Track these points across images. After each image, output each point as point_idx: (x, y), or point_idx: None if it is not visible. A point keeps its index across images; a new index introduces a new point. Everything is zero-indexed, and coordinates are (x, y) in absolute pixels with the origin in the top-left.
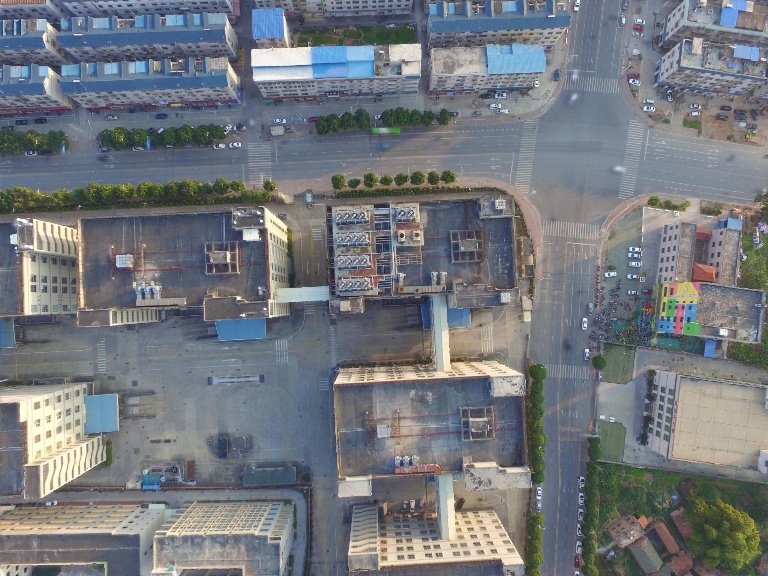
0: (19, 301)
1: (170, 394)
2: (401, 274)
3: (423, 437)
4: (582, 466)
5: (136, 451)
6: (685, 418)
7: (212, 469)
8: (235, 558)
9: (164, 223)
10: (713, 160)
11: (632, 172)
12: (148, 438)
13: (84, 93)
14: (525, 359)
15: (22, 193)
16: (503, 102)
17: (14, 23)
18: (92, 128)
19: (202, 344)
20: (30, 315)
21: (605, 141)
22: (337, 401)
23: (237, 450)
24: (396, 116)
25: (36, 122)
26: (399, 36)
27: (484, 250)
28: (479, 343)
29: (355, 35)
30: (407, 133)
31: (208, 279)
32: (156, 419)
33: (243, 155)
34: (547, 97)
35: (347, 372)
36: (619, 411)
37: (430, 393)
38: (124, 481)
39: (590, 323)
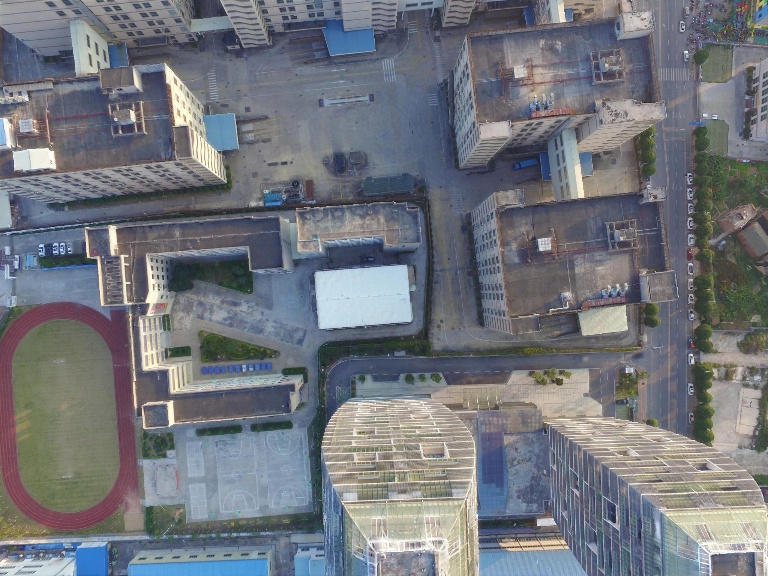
0: None
1: (283, 118)
2: None
3: (555, 84)
4: (688, 164)
5: (254, 175)
6: None
7: (330, 188)
8: (375, 229)
9: None
10: None
11: None
12: (265, 161)
13: None
14: None
15: None
16: None
17: None
18: None
19: (310, 68)
20: (144, 35)
21: None
22: None
23: (353, 168)
24: None
25: None
26: None
27: None
28: None
29: None
30: None
31: None
32: (271, 143)
33: None
34: None
35: None
36: (721, 109)
37: (559, 42)
38: (245, 204)
39: (687, 26)
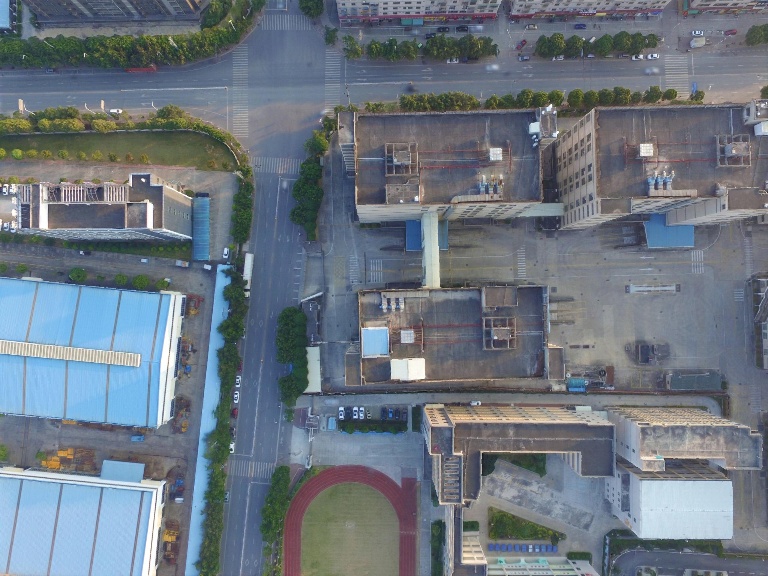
0: None
1: (588, 301)
2: None
3: None
4: None
5: None
6: None
7: (630, 375)
8: (714, 450)
9: (673, 116)
10: None
11: None
12: (567, 343)
13: None
14: None
15: (461, 97)
16: None
17: None
18: (511, 37)
19: (619, 253)
20: (472, 217)
21: None
22: None
23: (654, 357)
24: None
25: (458, 30)
26: None
27: None
28: None
29: None
30: None
31: (716, 172)
32: (575, 325)
33: (660, 67)
34: None
35: None
36: None
37: None
38: (544, 384)
39: None
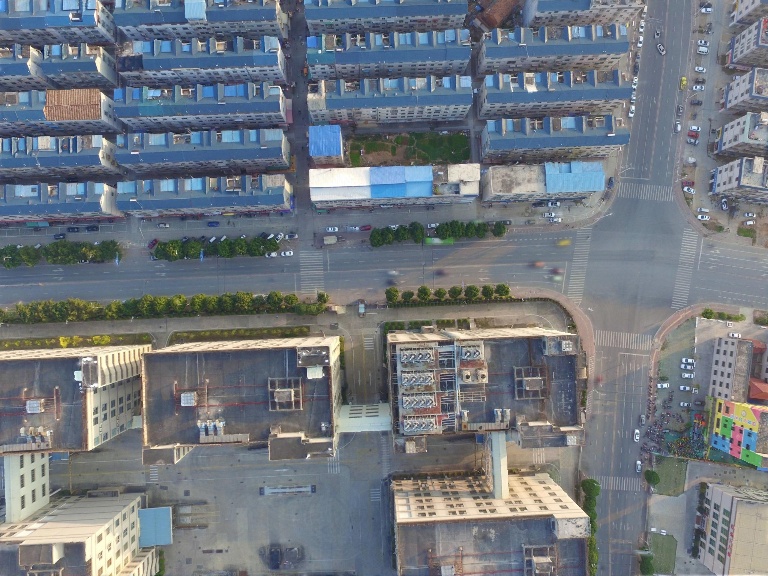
0: (84, 439)
1: (222, 504)
2: (466, 413)
3: (486, 575)
4: None
5: (188, 561)
6: (741, 541)
7: None
8: None
9: (227, 358)
10: (767, 269)
11: (685, 281)
12: (200, 548)
13: (140, 210)
14: (577, 471)
15: (76, 306)
16: (556, 210)
17: (70, 140)
18: (144, 236)
19: (254, 454)
20: None
21: (659, 250)
22: (400, 538)
23: None
24: (451, 231)
25: (88, 230)
26: (452, 143)
27: (548, 387)
28: (531, 454)
29: (408, 142)
30: (460, 242)
31: (271, 414)
32: (208, 529)
33: (295, 263)
34: (601, 205)
35: (402, 491)
36: (670, 523)
37: (493, 530)
38: None
39: (642, 435)
